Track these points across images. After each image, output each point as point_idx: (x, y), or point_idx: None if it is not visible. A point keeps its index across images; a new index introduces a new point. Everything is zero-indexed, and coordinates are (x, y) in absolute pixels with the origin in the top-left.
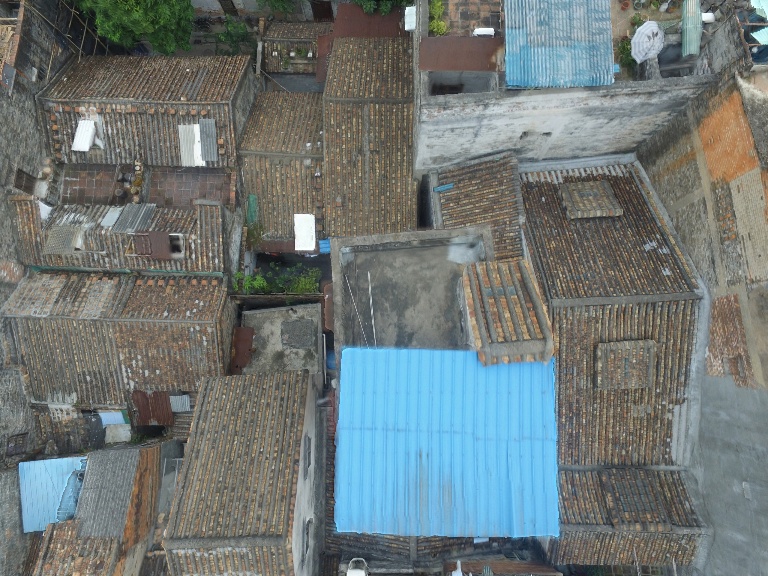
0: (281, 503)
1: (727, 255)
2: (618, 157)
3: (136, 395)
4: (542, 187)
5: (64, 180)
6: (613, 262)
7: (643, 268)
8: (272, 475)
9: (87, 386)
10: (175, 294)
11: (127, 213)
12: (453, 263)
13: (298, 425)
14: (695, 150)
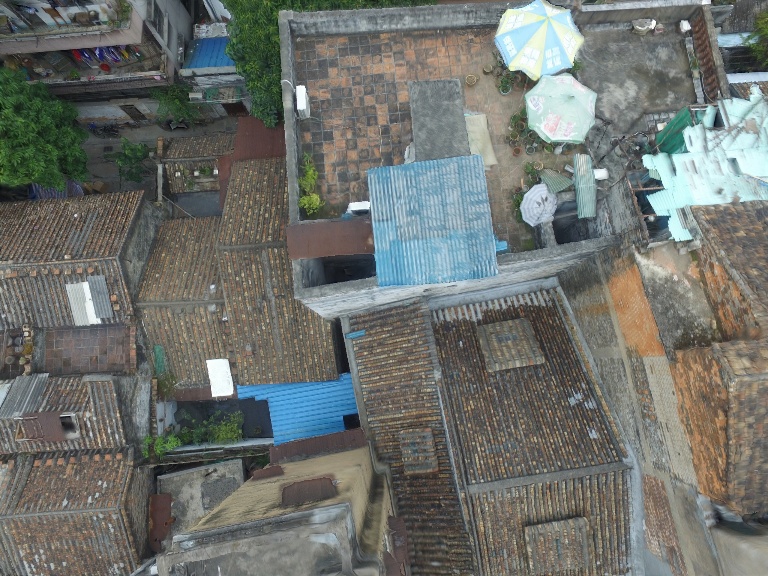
0: None
1: (650, 434)
2: (540, 281)
3: None
4: (460, 327)
5: None
6: (536, 425)
7: (568, 431)
8: None
9: None
10: (76, 475)
11: (16, 390)
12: (317, 543)
13: None
14: (608, 304)
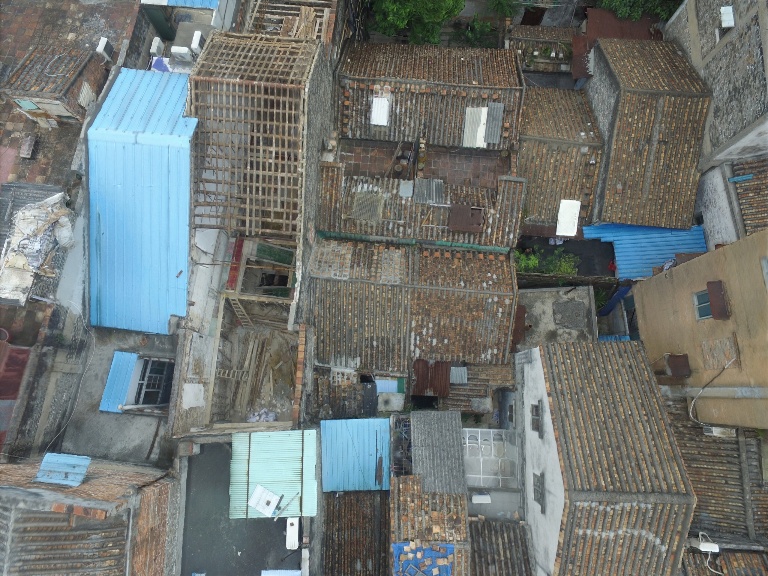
0: (673, 463)
1: None
2: None
3: (418, 364)
4: None
5: (340, 154)
6: None
7: None
8: (651, 437)
9: (372, 351)
10: (465, 266)
11: (419, 186)
12: None
13: (658, 391)
14: None
